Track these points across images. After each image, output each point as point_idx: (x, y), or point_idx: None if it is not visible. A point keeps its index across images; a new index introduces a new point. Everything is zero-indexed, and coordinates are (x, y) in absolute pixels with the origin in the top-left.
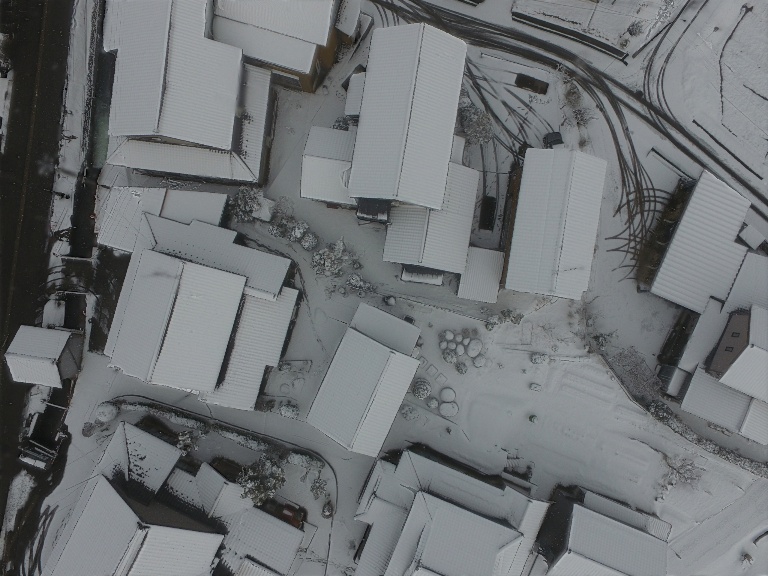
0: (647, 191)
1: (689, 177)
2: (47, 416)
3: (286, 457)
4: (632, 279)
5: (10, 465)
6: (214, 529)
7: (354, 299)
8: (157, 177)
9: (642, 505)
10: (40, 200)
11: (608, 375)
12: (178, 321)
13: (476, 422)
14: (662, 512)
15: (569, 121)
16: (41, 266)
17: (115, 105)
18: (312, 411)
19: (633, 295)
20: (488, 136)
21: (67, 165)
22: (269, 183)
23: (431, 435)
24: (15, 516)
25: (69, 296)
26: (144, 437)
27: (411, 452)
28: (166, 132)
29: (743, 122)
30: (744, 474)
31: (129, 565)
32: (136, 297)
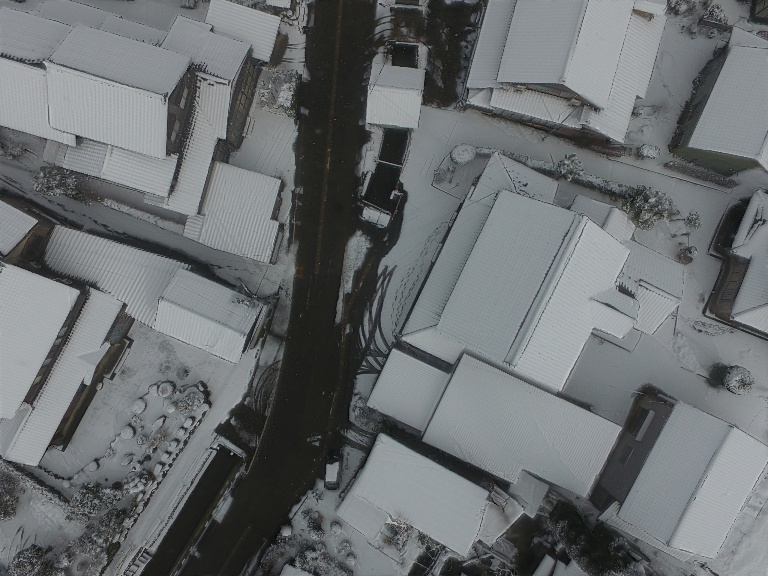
0: None
1: None
2: (374, 179)
3: None
4: None
5: (344, 225)
6: None
7: (702, 41)
8: None
9: None
10: None
11: None
12: (589, 18)
13: None
14: None
15: None
16: (367, 18)
17: None
18: (697, 134)
19: None
20: None
21: None
22: None
23: None
24: (352, 277)
25: (396, 50)
26: (520, 167)
27: None
28: None
29: None
30: None
31: None
32: (528, 5)
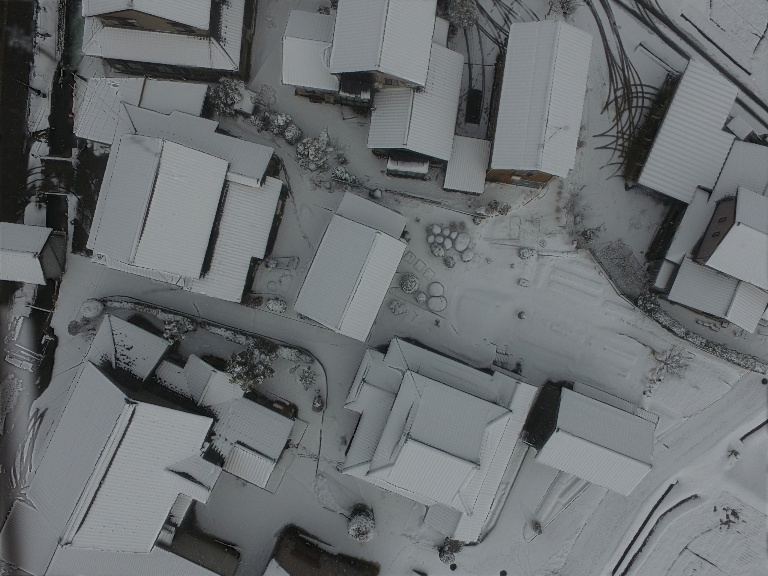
0: (635, 87)
1: (677, 72)
2: (32, 321)
3: (275, 351)
4: (620, 177)
5: None
6: (203, 415)
7: (340, 195)
8: (136, 75)
9: (630, 399)
10: (16, 100)
11: (596, 270)
12: (160, 202)
13: (465, 317)
14: (650, 409)
15: (555, 7)
16: (20, 168)
17: None
18: (299, 299)
19: (621, 193)
20: (472, 18)
21: (42, 63)
22: (251, 79)
23: (420, 330)
24: (4, 420)
25: (50, 198)
26: (130, 329)
27: (399, 339)
28: (141, 7)
29: (731, 16)
30: (731, 370)
31: (117, 441)
32: (116, 182)
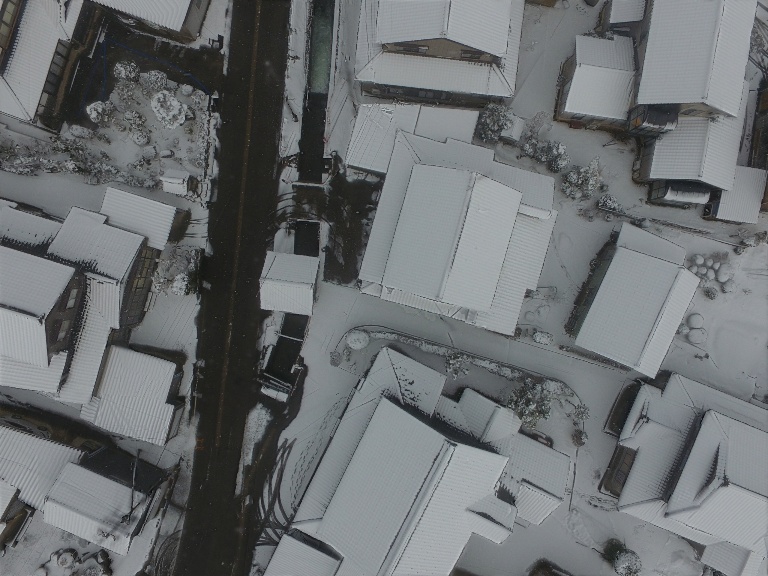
0: None
1: None
2: (277, 349)
3: None
4: None
5: (245, 398)
6: None
7: (600, 223)
8: (386, 99)
9: None
10: (267, 124)
11: None
12: (467, 236)
13: (723, 349)
14: None
15: None
16: (270, 193)
17: (385, 10)
18: (582, 333)
19: None
20: (763, 44)
21: (294, 87)
22: (506, 104)
23: (679, 362)
24: (252, 450)
25: (299, 225)
26: (408, 362)
27: (680, 375)
28: (453, 35)
29: None
30: None
31: None
32: (411, 214)
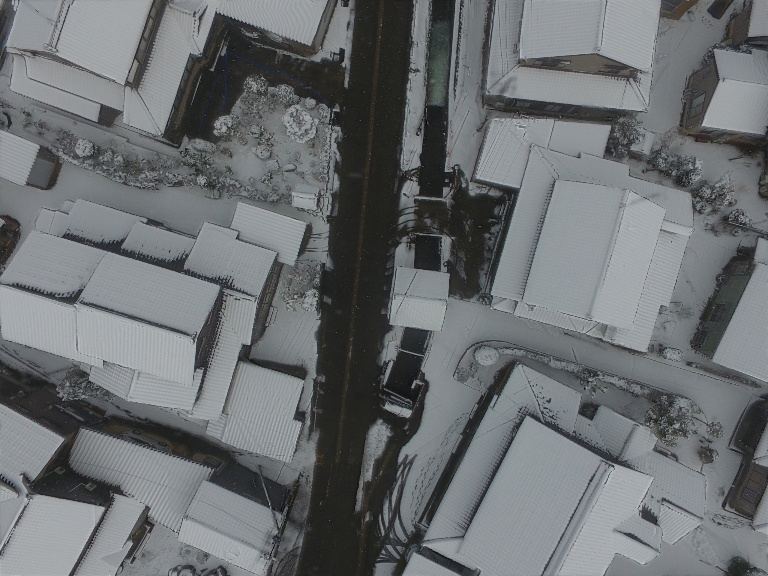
0: None
1: None
2: (395, 364)
3: None
4: None
5: (365, 414)
6: None
7: (726, 238)
8: (507, 112)
9: None
10: (388, 138)
11: None
12: (617, 254)
13: None
14: None
15: None
16: (391, 207)
17: (530, 25)
18: (721, 351)
19: None
20: None
21: (415, 100)
22: None
23: None
24: (372, 466)
25: (419, 239)
26: (544, 380)
27: None
28: (605, 51)
29: None
30: None
31: None
32: (555, 231)
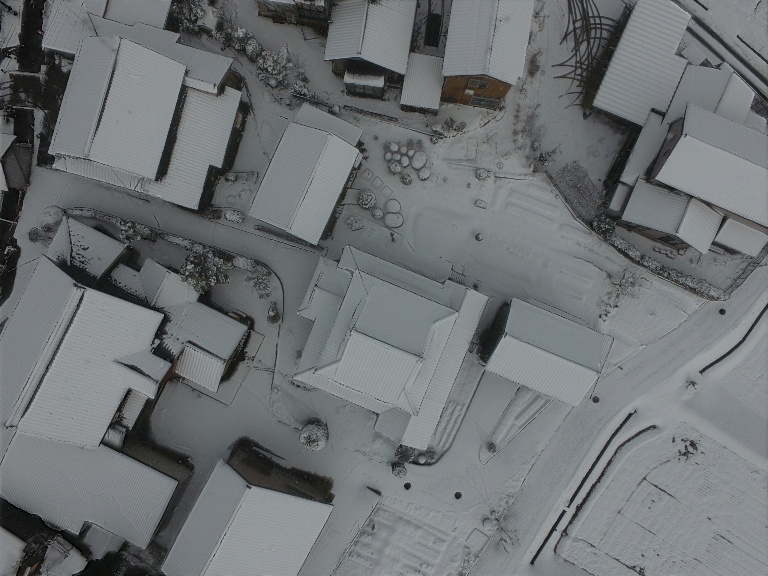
0: (593, 19)
1: None
2: None
3: (231, 260)
4: (578, 105)
5: None
6: None
7: None
8: None
9: None
10: None
11: (553, 194)
12: (116, 98)
13: (421, 234)
14: None
15: None
16: None
17: None
18: (254, 204)
19: (579, 121)
20: None
21: None
22: (216, 1)
23: (376, 246)
24: None
25: (18, 113)
26: (88, 231)
27: (352, 247)
28: None
29: None
30: (688, 298)
31: (65, 326)
32: (76, 83)
